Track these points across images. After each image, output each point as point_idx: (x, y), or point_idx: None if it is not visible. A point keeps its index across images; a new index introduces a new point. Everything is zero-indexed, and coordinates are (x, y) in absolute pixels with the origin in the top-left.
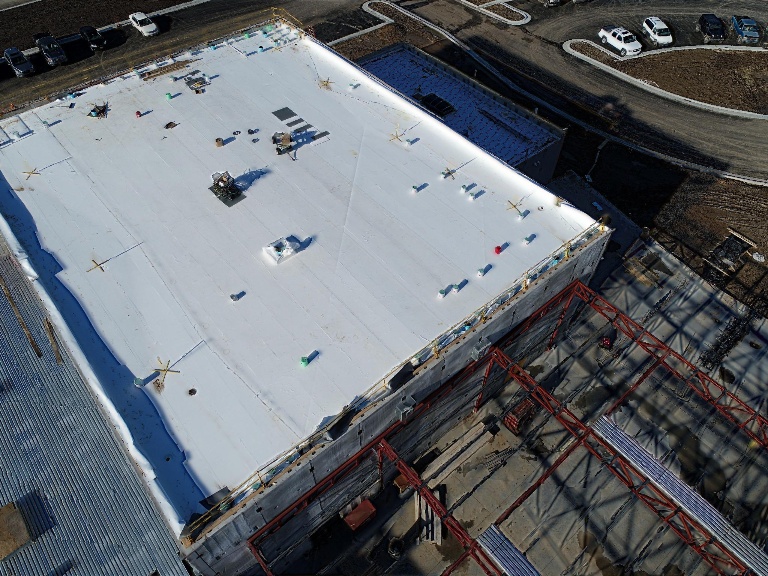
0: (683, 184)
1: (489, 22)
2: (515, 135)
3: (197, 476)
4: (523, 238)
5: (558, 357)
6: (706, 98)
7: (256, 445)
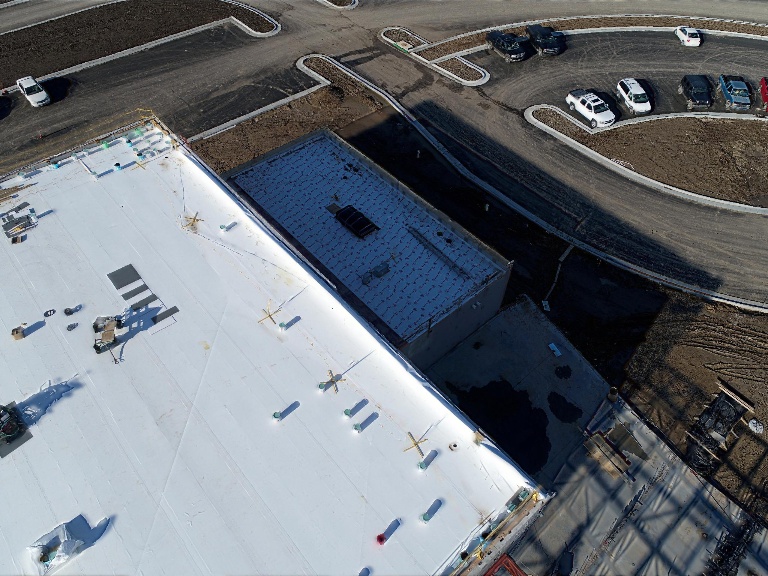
0: (662, 312)
1: (441, 82)
2: (449, 267)
3: None
4: (422, 508)
5: None
6: (690, 185)
7: None
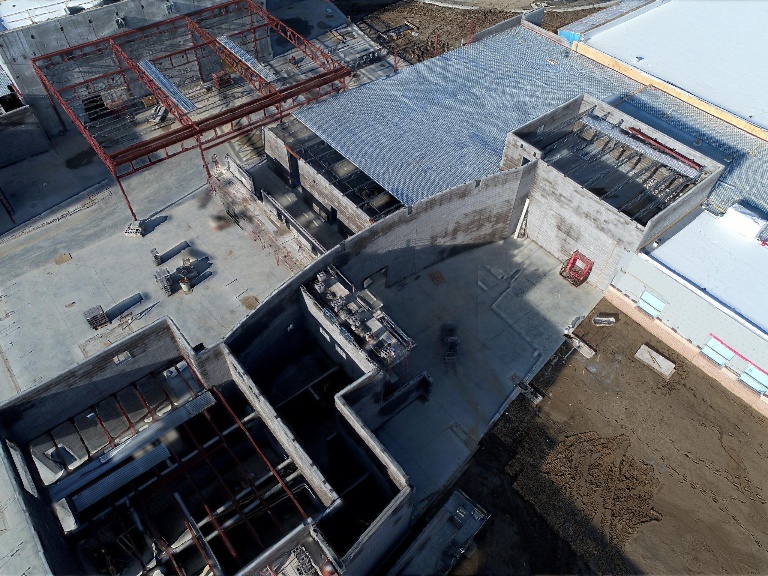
0: (394, 4)
1: None
2: None
3: (7, 25)
4: None
5: None
6: None
7: (37, 19)
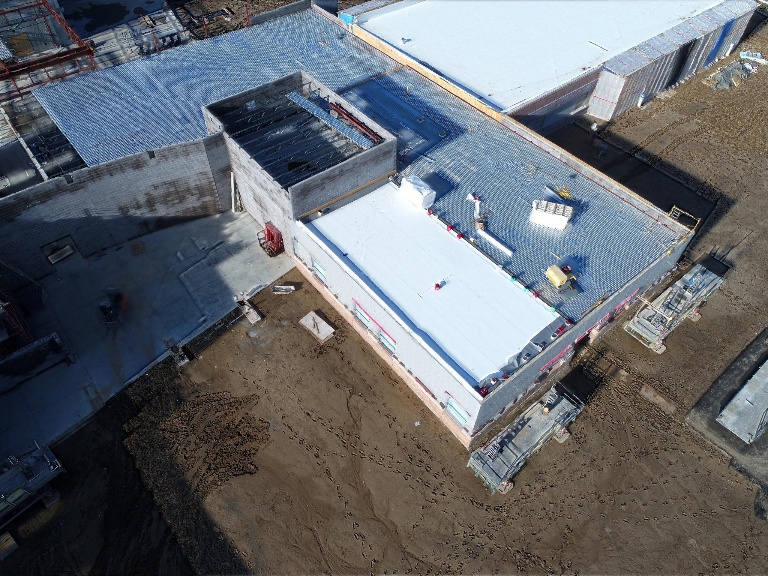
0: None
1: None
2: None
3: None
4: None
5: (61, 50)
6: None
7: None
